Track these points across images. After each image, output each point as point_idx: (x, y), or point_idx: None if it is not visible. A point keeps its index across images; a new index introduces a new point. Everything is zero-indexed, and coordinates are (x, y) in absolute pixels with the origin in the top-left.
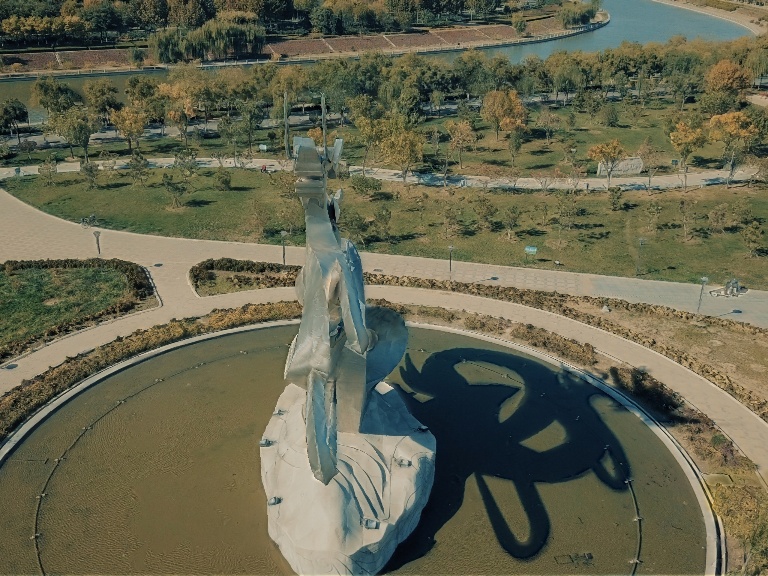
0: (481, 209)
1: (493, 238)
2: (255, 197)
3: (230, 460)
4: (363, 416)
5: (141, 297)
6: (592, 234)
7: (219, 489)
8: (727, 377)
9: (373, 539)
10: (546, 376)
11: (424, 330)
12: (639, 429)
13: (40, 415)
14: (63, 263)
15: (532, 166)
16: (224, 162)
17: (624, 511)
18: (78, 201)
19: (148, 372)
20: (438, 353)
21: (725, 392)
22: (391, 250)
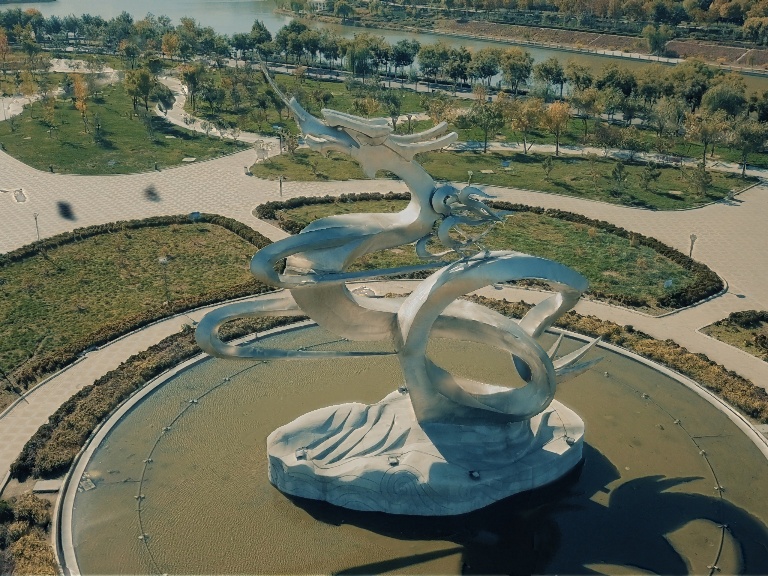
0: None
1: None
2: None
3: None
4: (451, 422)
5: (663, 304)
6: None
7: None
8: None
9: (288, 461)
10: None
11: None
12: None
13: None
14: (677, 256)
15: None
16: None
17: None
18: None
19: None
20: (728, 502)
21: None
22: None
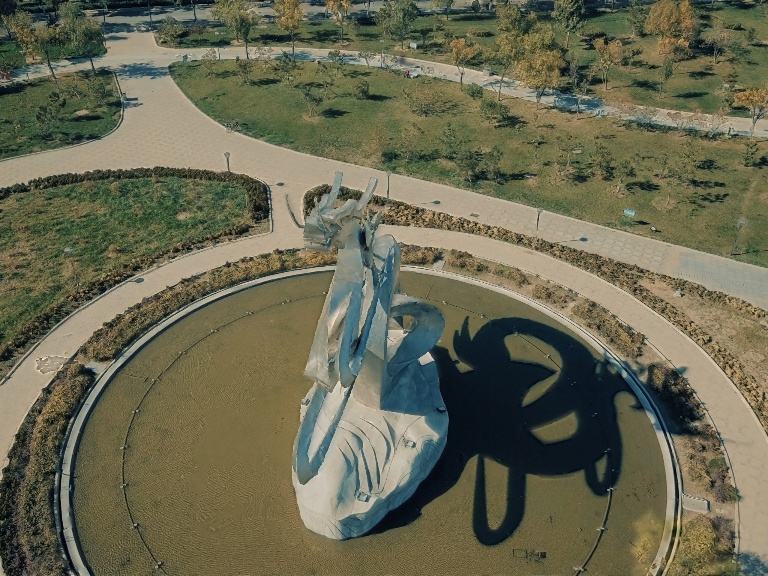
0: (597, 155)
1: (602, 188)
2: (388, 110)
3: (284, 403)
4: (390, 392)
5: (257, 220)
6: (707, 195)
7: (267, 430)
8: (763, 394)
9: (361, 510)
10: (586, 362)
11: (492, 292)
12: (647, 436)
13: (150, 334)
14: (200, 174)
15: (683, 93)
16: (373, 59)
17: (593, 518)
18: (230, 98)
19: (243, 302)
20: (496, 320)
21: (752, 411)
22: (495, 192)
